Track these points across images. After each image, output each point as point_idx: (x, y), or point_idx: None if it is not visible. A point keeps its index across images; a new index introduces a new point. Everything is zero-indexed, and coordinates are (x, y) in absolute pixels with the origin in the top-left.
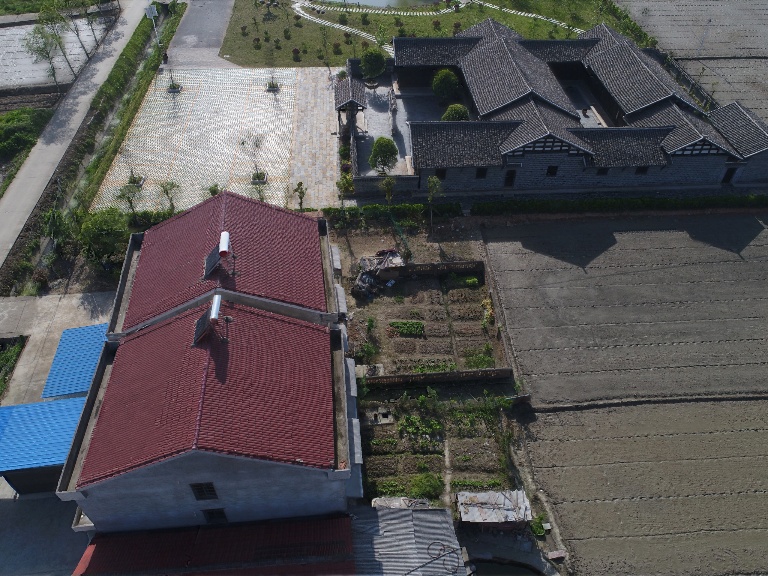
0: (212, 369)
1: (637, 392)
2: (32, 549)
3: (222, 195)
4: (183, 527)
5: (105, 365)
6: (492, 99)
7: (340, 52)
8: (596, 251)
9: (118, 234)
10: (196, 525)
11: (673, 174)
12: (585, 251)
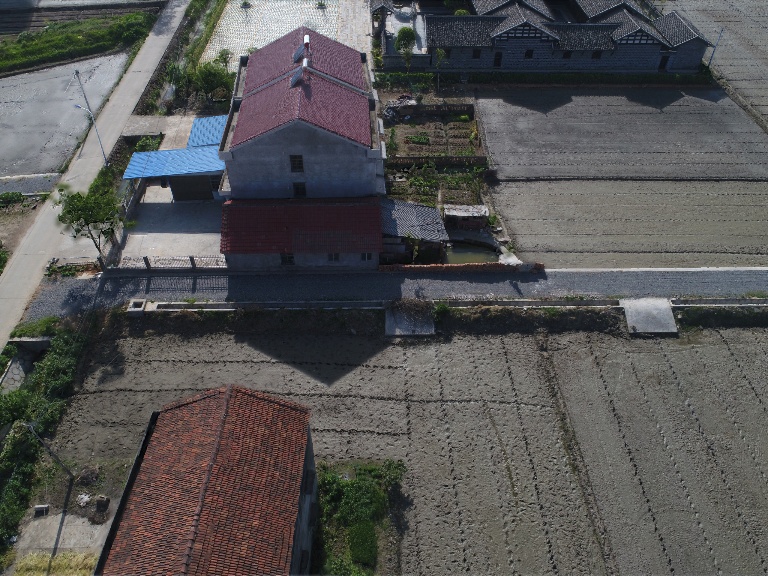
0: (303, 94)
1: (570, 174)
2: (187, 222)
3: (301, 28)
4: (280, 198)
5: (233, 112)
6: (488, 5)
7: None
8: (556, 105)
9: (221, 77)
10: (288, 198)
11: (620, 60)
12: (548, 105)
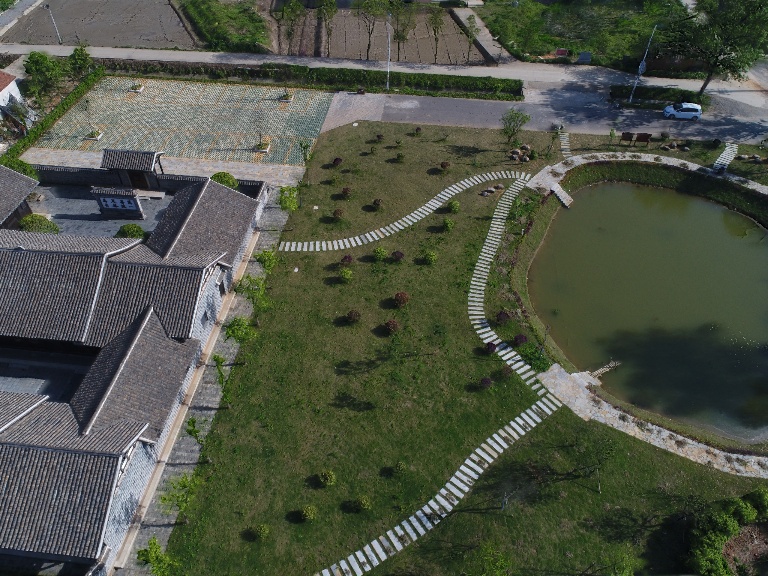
0: None
1: None
2: None
3: None
4: None
5: None
6: None
7: (338, 198)
8: None
9: None
10: None
11: None
12: None
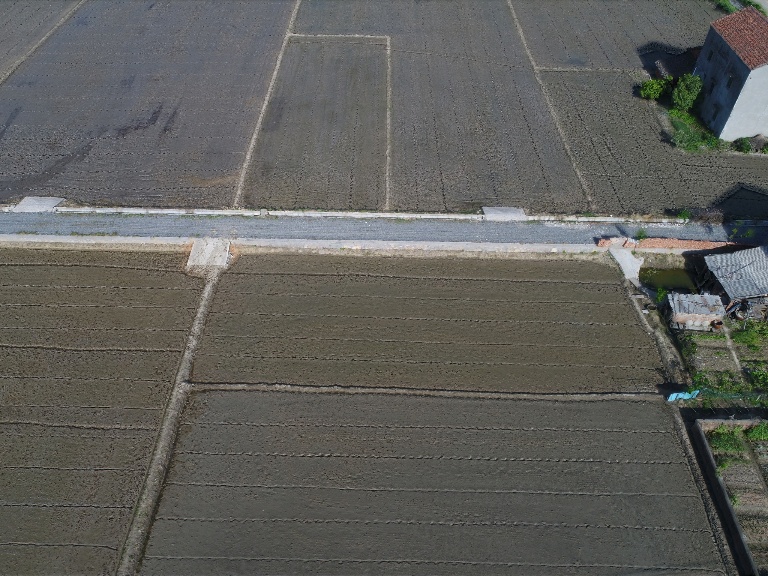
0: None
1: (554, 405)
2: None
3: None
4: None
5: None
6: None
7: None
8: None
9: None
10: None
11: None
12: None
